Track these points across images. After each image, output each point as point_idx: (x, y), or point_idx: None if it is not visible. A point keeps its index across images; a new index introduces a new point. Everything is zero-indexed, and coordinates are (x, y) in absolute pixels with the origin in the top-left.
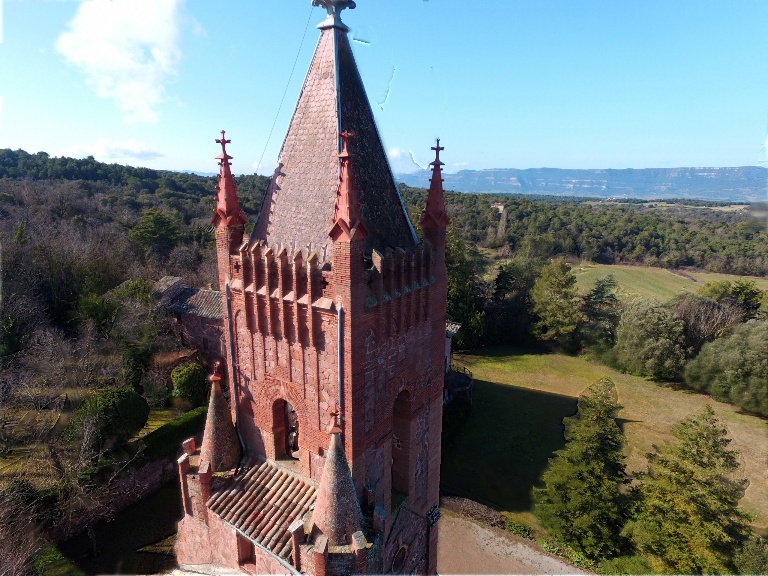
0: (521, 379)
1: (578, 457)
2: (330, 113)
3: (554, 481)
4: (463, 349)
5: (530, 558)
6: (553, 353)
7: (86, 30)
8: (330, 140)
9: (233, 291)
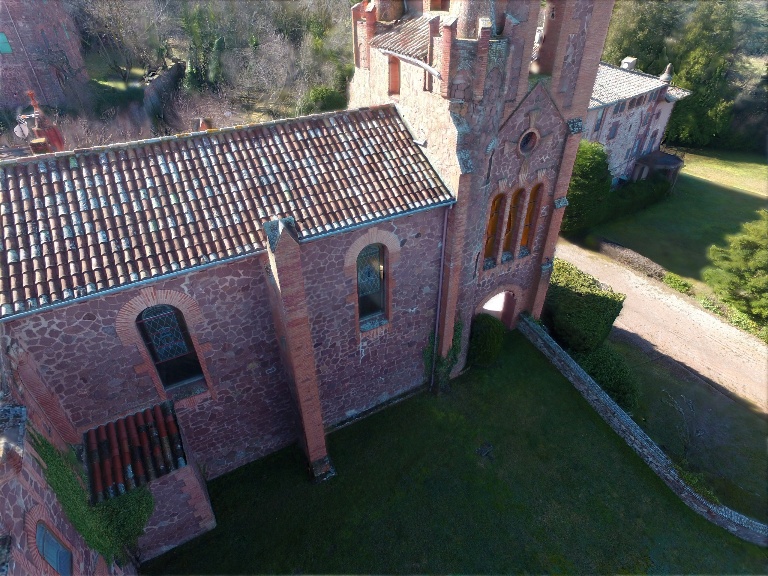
0: (752, 184)
1: None
2: None
3: None
4: (685, 146)
5: (680, 307)
6: None
7: None
8: None
9: None
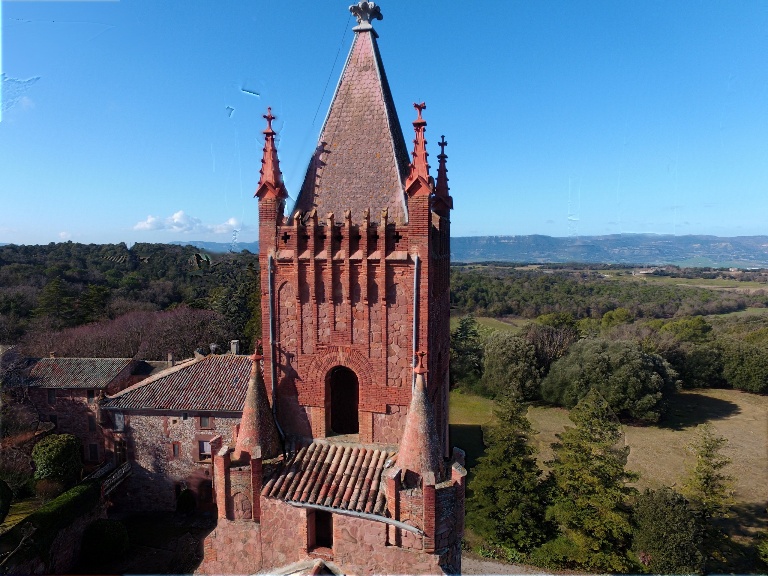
0: None
1: (501, 457)
2: (376, 98)
3: (482, 485)
4: None
5: (472, 567)
6: None
7: (68, 8)
8: (379, 120)
9: (279, 263)
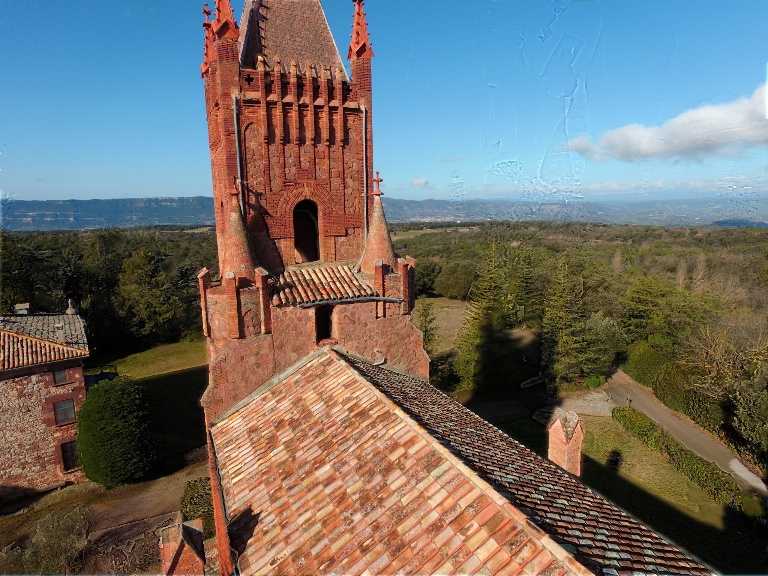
0: (146, 371)
1: None
2: None
3: None
4: None
5: None
6: (155, 346)
7: None
8: None
9: (244, 104)
